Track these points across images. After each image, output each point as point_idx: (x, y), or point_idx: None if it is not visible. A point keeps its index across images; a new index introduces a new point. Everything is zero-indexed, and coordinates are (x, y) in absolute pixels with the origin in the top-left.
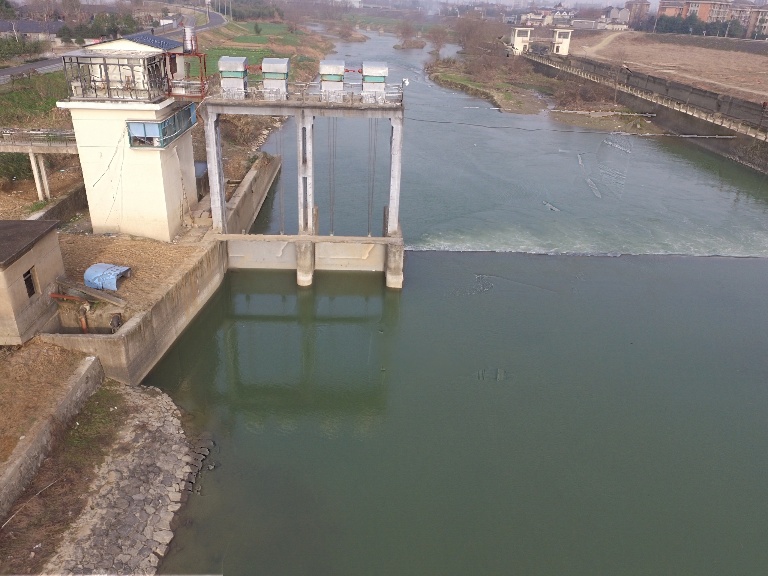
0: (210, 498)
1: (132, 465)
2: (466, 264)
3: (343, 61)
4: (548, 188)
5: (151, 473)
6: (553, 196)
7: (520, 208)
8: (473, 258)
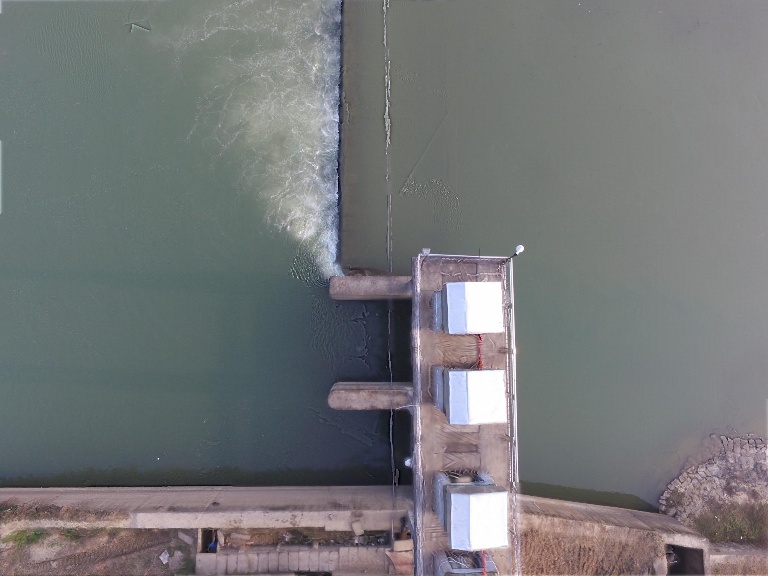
0: (763, 426)
1: (764, 484)
2: (375, 199)
3: (476, 375)
4: (82, 7)
5: (763, 469)
6: (110, 10)
7: (127, 72)
8: (360, 187)
